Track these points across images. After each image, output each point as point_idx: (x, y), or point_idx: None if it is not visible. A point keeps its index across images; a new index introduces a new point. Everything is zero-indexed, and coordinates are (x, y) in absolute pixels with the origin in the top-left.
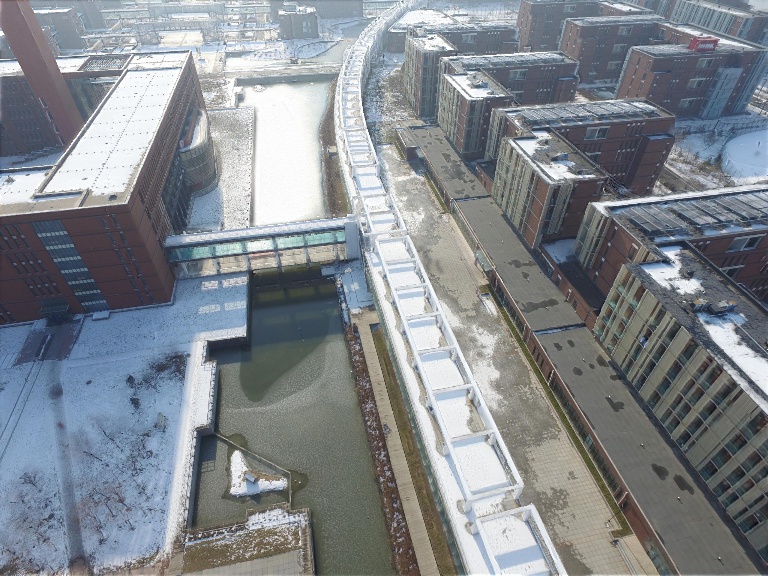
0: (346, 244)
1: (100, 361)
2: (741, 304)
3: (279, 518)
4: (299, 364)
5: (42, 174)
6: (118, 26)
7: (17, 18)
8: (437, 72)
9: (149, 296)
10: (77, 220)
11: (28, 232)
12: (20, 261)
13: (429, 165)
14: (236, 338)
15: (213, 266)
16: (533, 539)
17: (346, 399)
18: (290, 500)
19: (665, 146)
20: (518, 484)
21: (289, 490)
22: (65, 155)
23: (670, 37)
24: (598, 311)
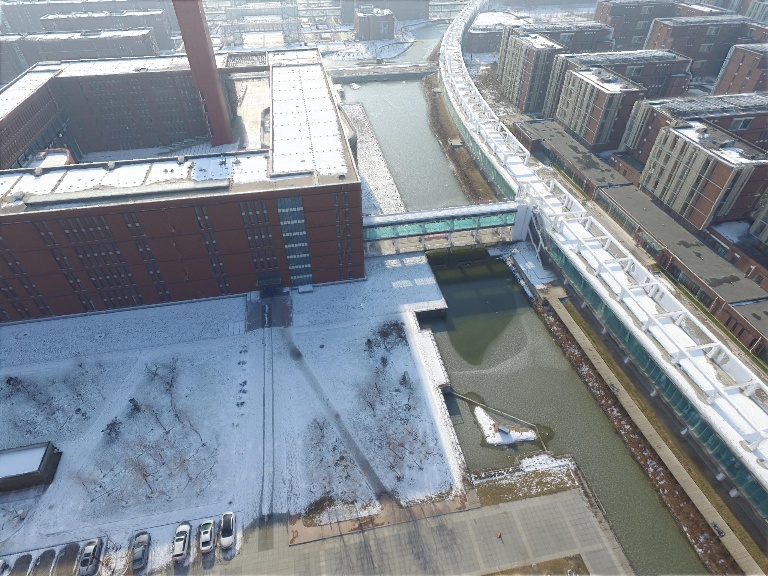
0: (513, 226)
1: (324, 328)
2: None
3: (548, 462)
4: (502, 333)
5: (261, 157)
6: None
7: (195, 16)
8: (546, 69)
9: (349, 271)
10: (315, 197)
11: (271, 208)
12: (254, 235)
13: (560, 156)
14: (439, 309)
15: (390, 246)
16: None
17: (559, 364)
18: (545, 448)
19: None
20: None
21: (541, 440)
22: (272, 140)
23: (760, 36)
24: None
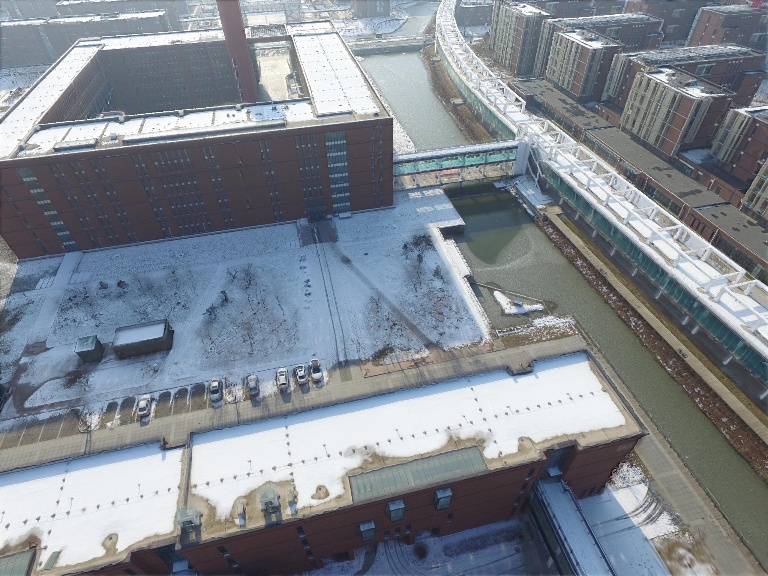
0: (515, 162)
1: (365, 242)
2: None
3: (554, 320)
4: (511, 242)
5: (305, 103)
6: (198, 12)
7: None
8: (534, 35)
9: (380, 200)
10: (356, 131)
11: (320, 141)
12: (305, 166)
13: (551, 107)
14: (458, 226)
15: (411, 182)
16: (757, 303)
17: (559, 260)
18: None
19: (757, 80)
20: (742, 271)
21: (547, 310)
22: None
23: (726, 1)
24: (742, 190)
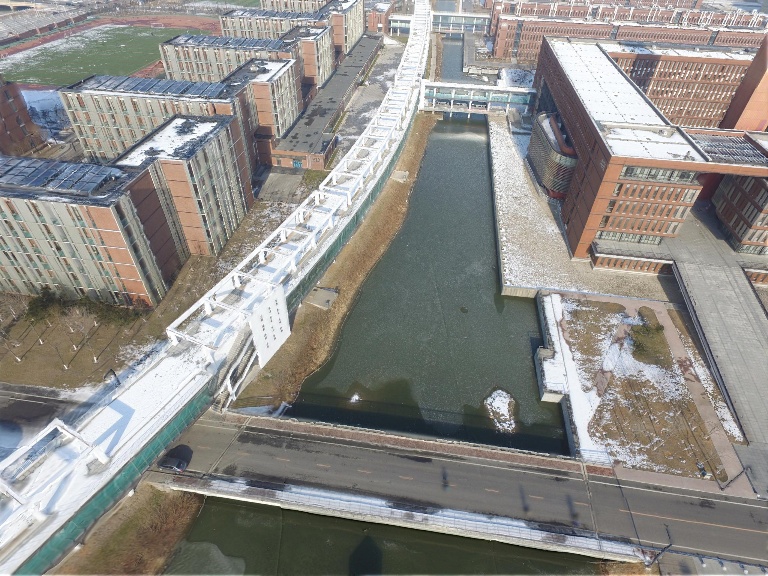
0: None
1: None
2: (325, 9)
3: None
4: None
5: None
6: None
7: None
8: None
9: None
10: None
11: None
12: None
13: None
14: None
15: (509, 112)
16: None
17: None
18: None
19: None
20: None
21: None
22: None
23: None
24: None
